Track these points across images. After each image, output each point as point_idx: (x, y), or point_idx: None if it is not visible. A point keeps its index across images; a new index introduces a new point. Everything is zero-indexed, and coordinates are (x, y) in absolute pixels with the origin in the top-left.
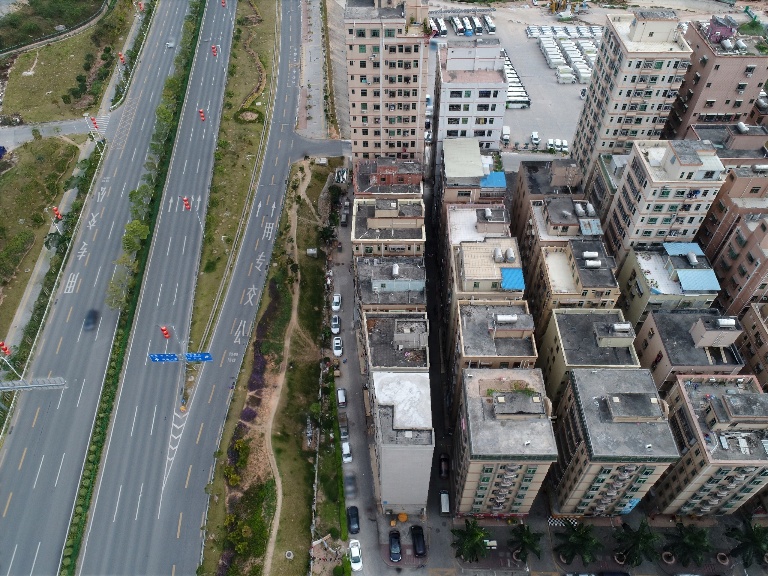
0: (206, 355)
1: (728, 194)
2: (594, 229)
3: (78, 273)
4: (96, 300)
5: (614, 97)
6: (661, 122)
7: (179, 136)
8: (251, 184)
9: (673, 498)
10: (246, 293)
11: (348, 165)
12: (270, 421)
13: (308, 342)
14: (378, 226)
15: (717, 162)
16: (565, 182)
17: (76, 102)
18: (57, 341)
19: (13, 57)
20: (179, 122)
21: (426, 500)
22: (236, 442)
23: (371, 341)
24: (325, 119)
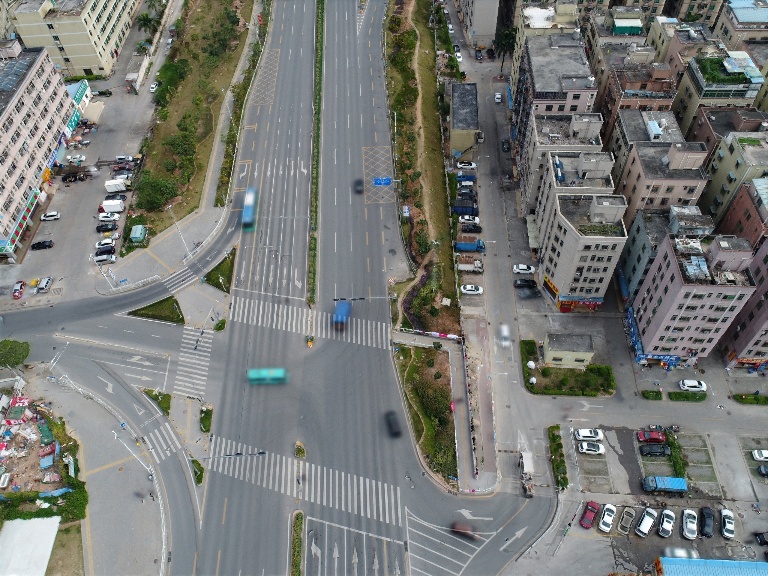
0: None
1: None
2: None
3: None
4: None
5: None
6: None
7: None
8: None
9: None
10: None
11: None
12: (409, 14)
13: None
14: None
15: None
16: None
17: None
18: None
19: None
20: None
21: (495, 29)
22: (394, 17)
23: None
24: None
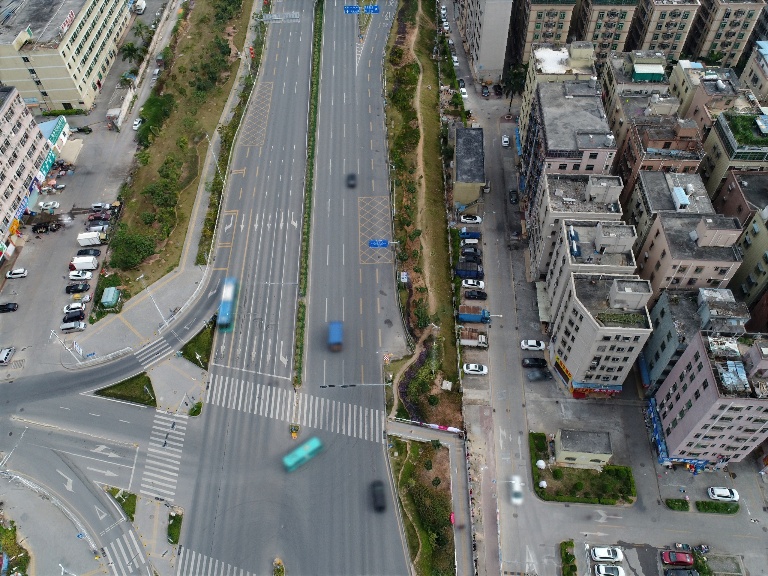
0: (376, 8)
1: None
2: None
3: None
4: (298, 4)
5: None
6: None
7: None
8: None
9: None
10: (388, 2)
11: None
12: (412, 45)
13: (429, 21)
14: None
15: None
16: None
17: None
18: None
19: None
20: None
21: None
22: (395, 48)
23: None
24: None
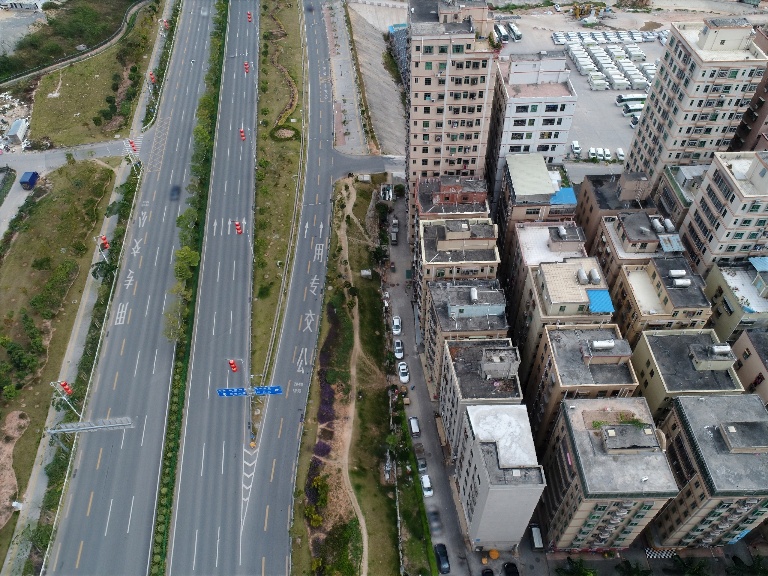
0: (276, 388)
1: None
2: (675, 245)
3: (127, 303)
4: (149, 331)
5: (685, 108)
6: (731, 131)
7: (216, 156)
8: (295, 204)
9: None
10: (304, 319)
11: (391, 181)
12: (345, 455)
13: (373, 369)
14: (448, 248)
15: None
16: (635, 196)
17: (106, 124)
18: (113, 376)
19: (37, 79)
20: (214, 141)
21: (521, 537)
22: (314, 479)
23: (456, 371)
24: (363, 134)
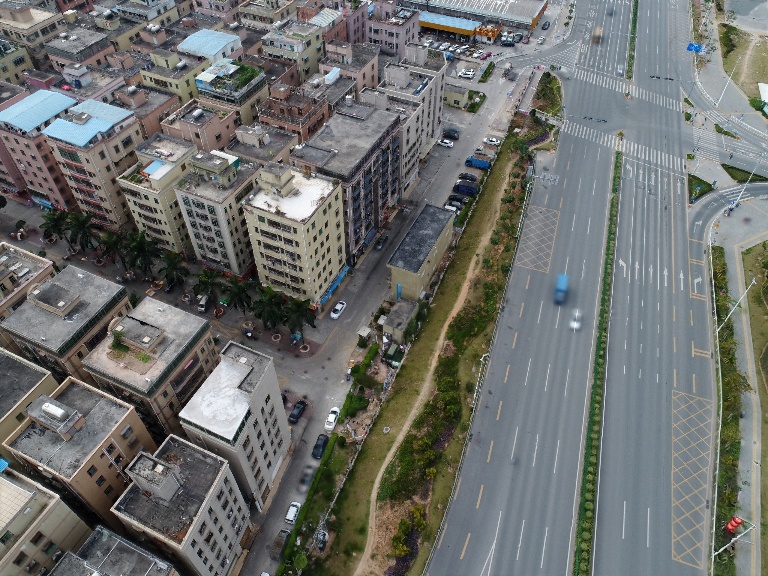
0: None
1: None
2: None
3: None
4: None
5: None
6: None
7: None
8: None
9: None
10: None
11: None
12: (359, 572)
13: None
14: None
15: None
16: None
17: None
18: None
19: None
20: None
21: None
22: (405, 553)
23: None
24: None
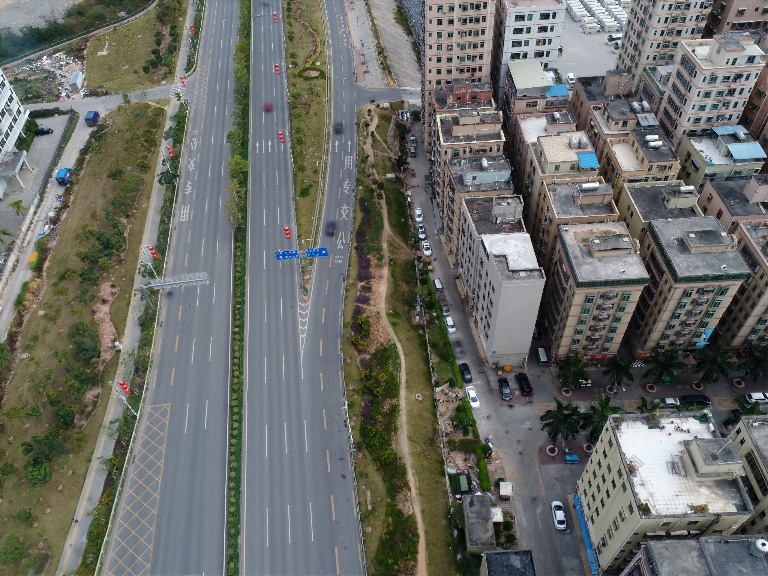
0: (323, 250)
1: (765, 81)
2: (651, 121)
3: (189, 205)
4: (210, 224)
5: (657, 12)
6: (699, 33)
7: (252, 94)
8: (325, 127)
9: (741, 326)
10: (340, 211)
11: (408, 108)
12: (382, 303)
13: (401, 245)
14: (462, 133)
15: (757, 49)
16: (618, 90)
17: (153, 73)
18: (184, 257)
19: (86, 41)
20: (250, 83)
21: (529, 347)
22: (358, 318)
23: (472, 219)
24: (381, 72)
